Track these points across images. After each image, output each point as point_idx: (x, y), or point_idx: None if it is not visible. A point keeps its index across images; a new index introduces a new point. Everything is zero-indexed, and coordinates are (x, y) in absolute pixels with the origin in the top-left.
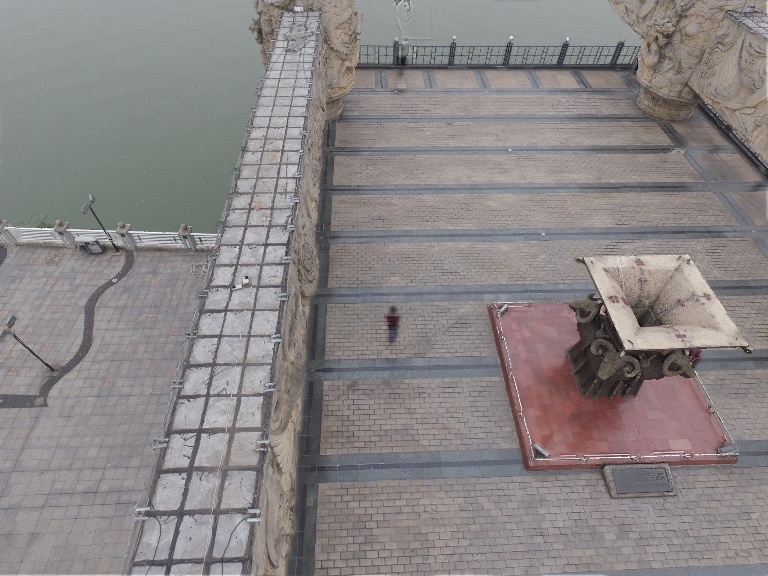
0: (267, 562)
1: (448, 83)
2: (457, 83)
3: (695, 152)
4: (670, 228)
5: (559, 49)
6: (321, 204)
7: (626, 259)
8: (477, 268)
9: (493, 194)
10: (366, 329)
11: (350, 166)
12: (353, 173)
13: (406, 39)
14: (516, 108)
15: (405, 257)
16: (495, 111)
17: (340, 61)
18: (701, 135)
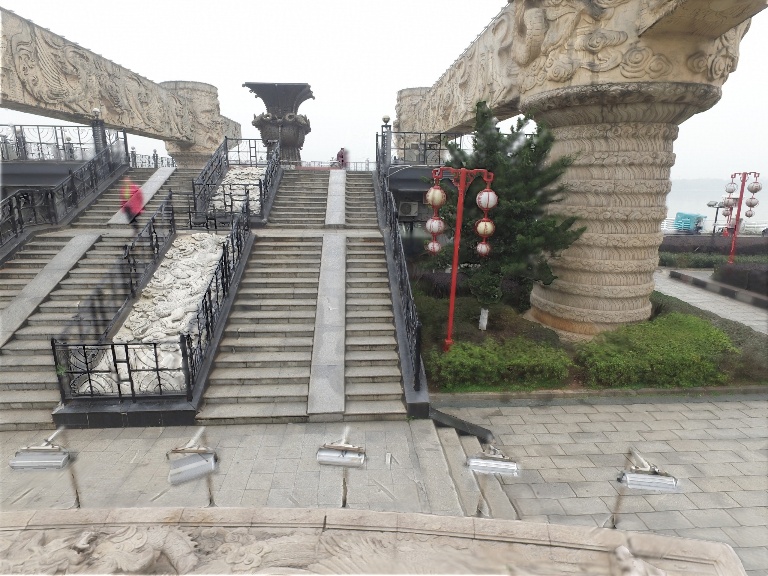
0: (9, 43)
1: None
2: None
3: None
4: None
5: (364, 164)
6: None
7: None
8: None
9: None
10: None
11: None
12: None
13: None
14: None
15: None
16: None
17: (205, 133)
18: None
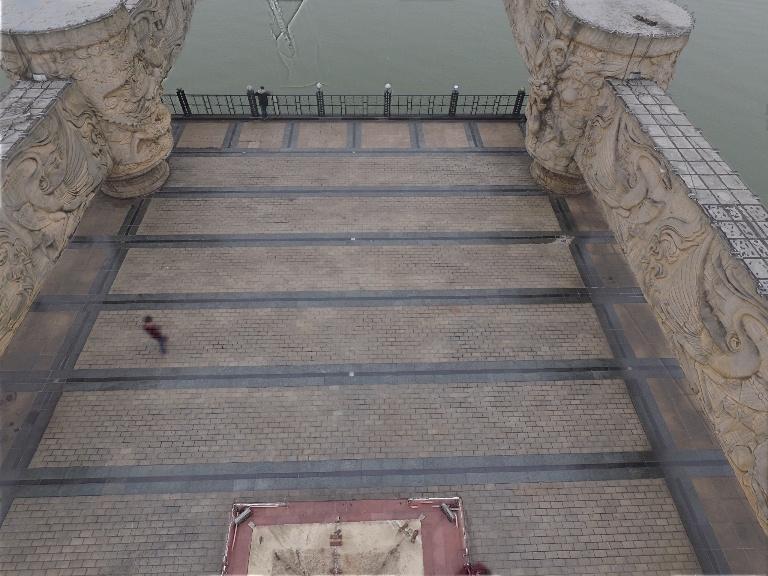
0: None
1: (311, 140)
2: (322, 140)
3: (584, 241)
4: (521, 363)
5: (448, 98)
6: (80, 325)
7: (318, 531)
8: (243, 433)
9: (308, 308)
10: (49, 545)
11: (142, 264)
12: (141, 275)
13: (263, 87)
14: (381, 176)
15: (154, 414)
16: (354, 181)
17: (128, 133)
18: (598, 216)
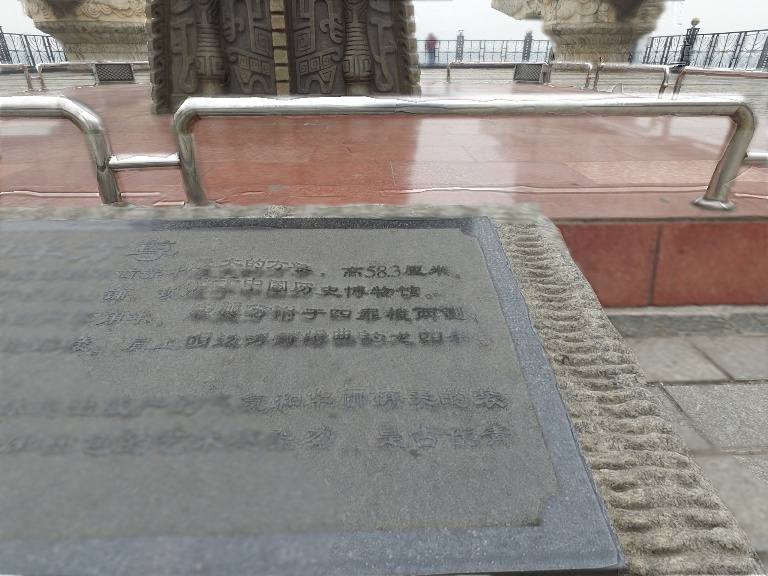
0: None
1: None
2: None
3: (636, 75)
4: None
5: (453, 44)
6: None
7: None
8: None
9: None
10: None
11: None
12: None
13: None
14: None
15: None
16: None
17: None
18: None
